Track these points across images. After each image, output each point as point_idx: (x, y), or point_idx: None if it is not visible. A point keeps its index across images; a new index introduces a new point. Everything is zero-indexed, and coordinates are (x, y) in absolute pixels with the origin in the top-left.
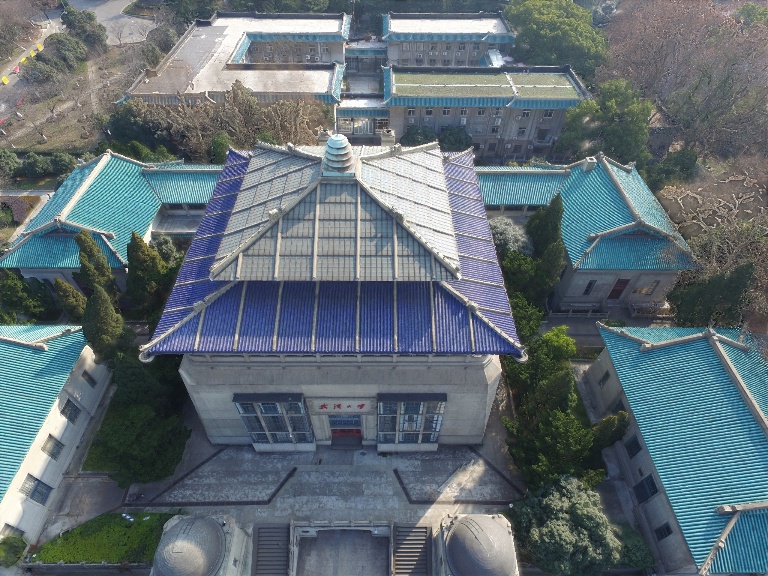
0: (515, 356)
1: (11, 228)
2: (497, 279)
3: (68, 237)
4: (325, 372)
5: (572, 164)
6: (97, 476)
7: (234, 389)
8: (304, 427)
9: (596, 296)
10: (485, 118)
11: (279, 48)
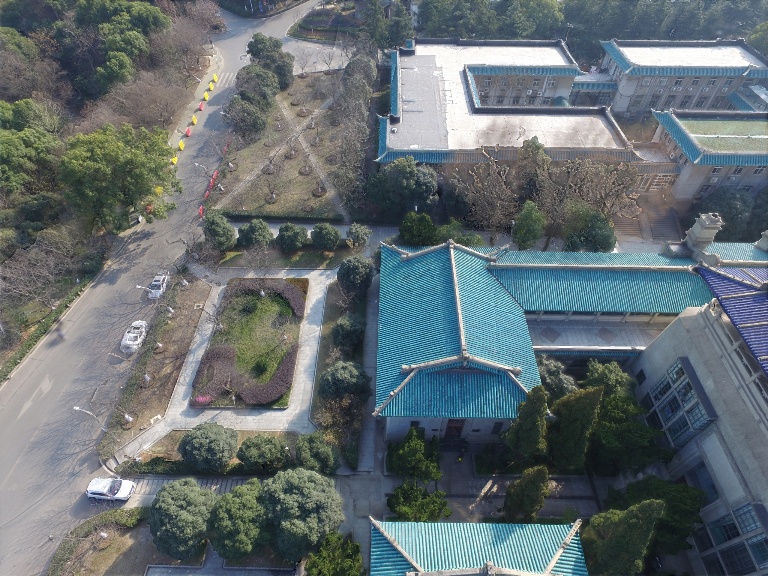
0: None
1: (293, 324)
2: None
3: (463, 374)
4: None
5: None
6: None
7: None
8: None
9: None
10: None
11: (499, 82)
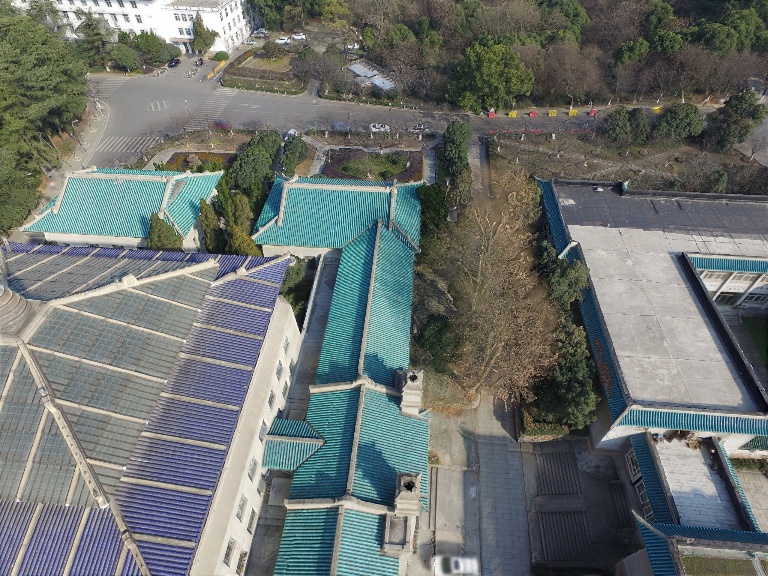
0: None
1: (382, 180)
2: None
3: None
4: None
5: None
6: None
7: None
8: None
9: None
10: None
11: None
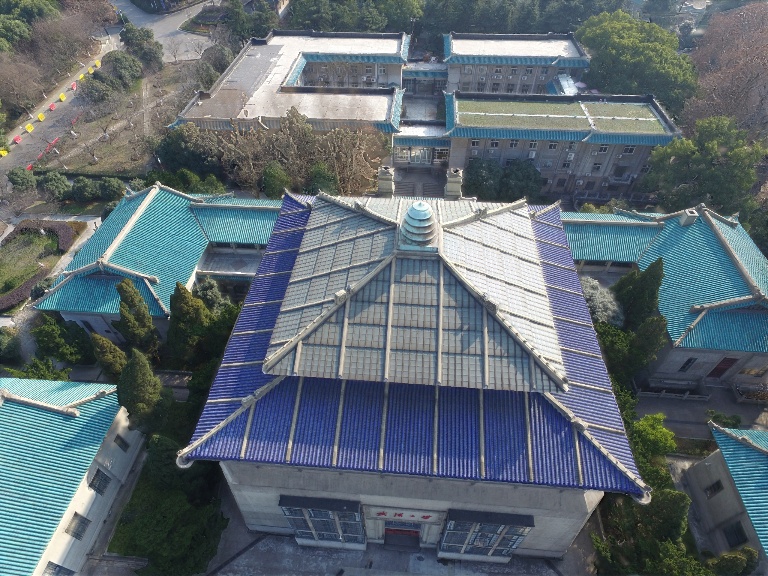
0: (635, 496)
1: (56, 256)
2: (603, 381)
3: (110, 279)
4: (389, 482)
5: (666, 215)
6: (123, 560)
7: (281, 491)
8: (357, 531)
9: (694, 374)
10: (556, 152)
11: (335, 69)
